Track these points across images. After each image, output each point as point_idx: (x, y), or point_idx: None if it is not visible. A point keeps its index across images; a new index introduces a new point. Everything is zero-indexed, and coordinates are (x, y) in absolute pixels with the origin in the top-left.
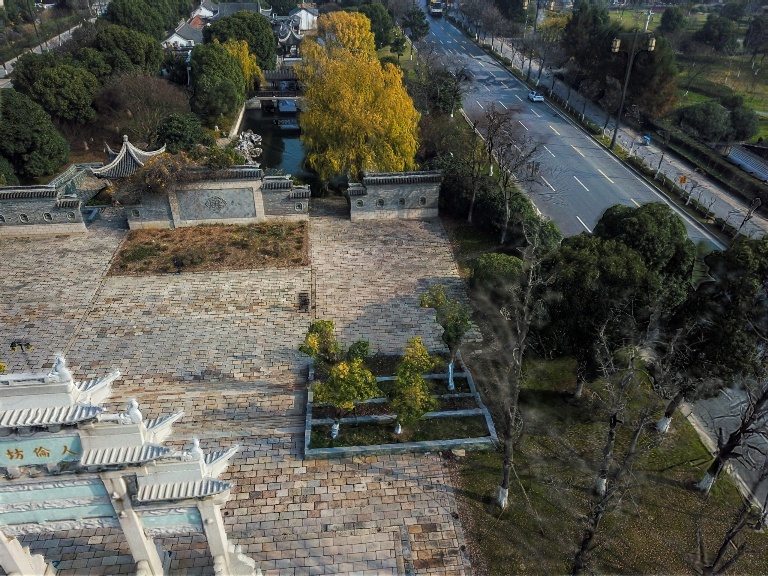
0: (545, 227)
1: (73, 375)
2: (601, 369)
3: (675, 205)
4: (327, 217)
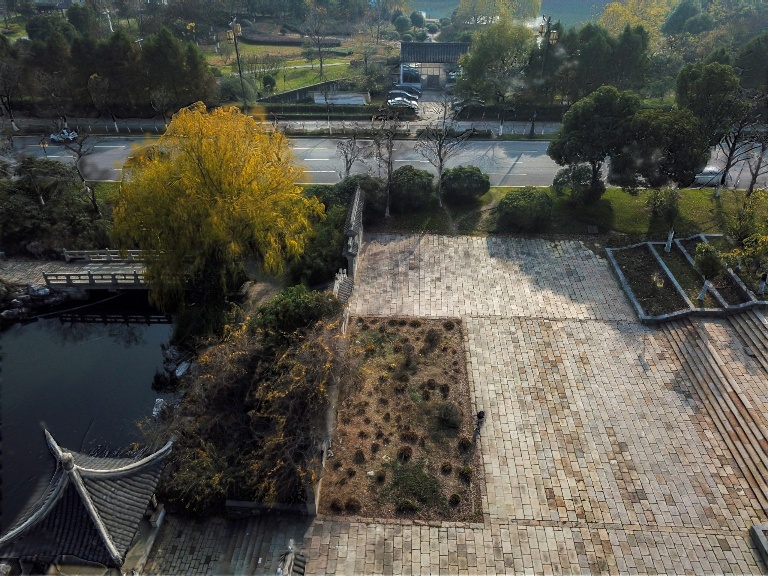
0: None
1: (730, 509)
2: None
3: None
4: None
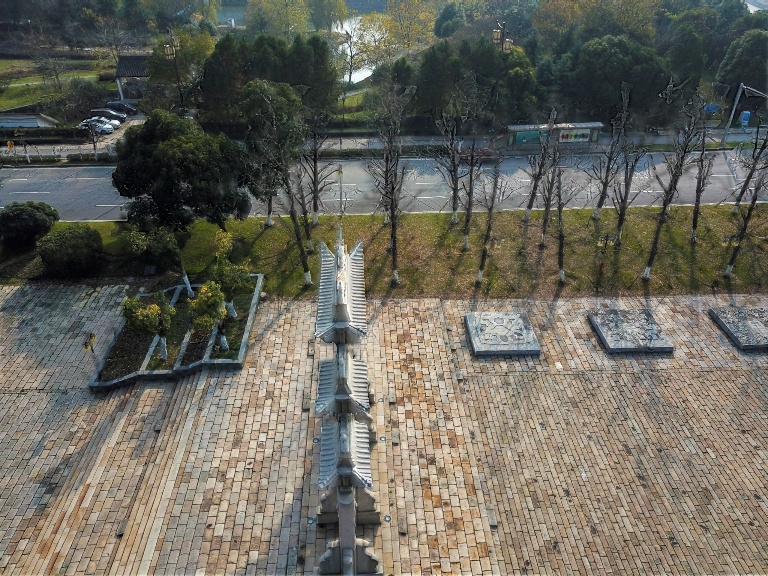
0: (34, 204)
1: None
2: (250, 202)
3: (24, 166)
4: None
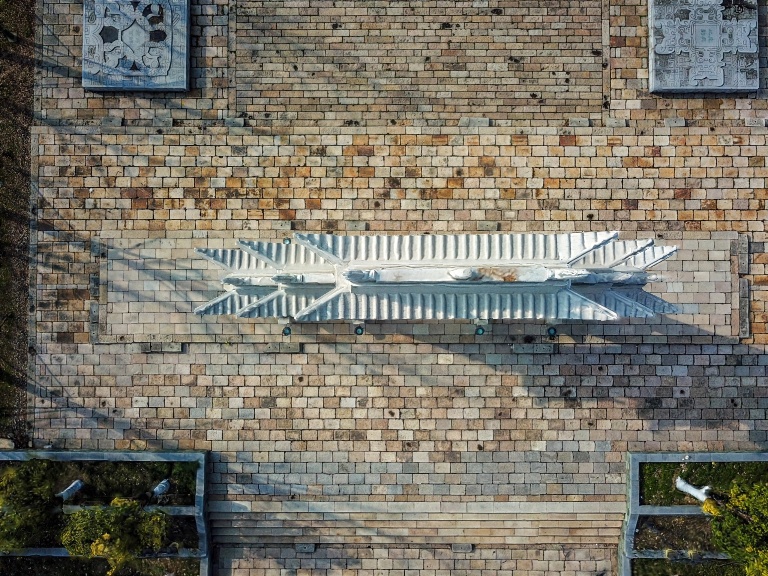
0: None
1: None
2: None
3: None
4: None
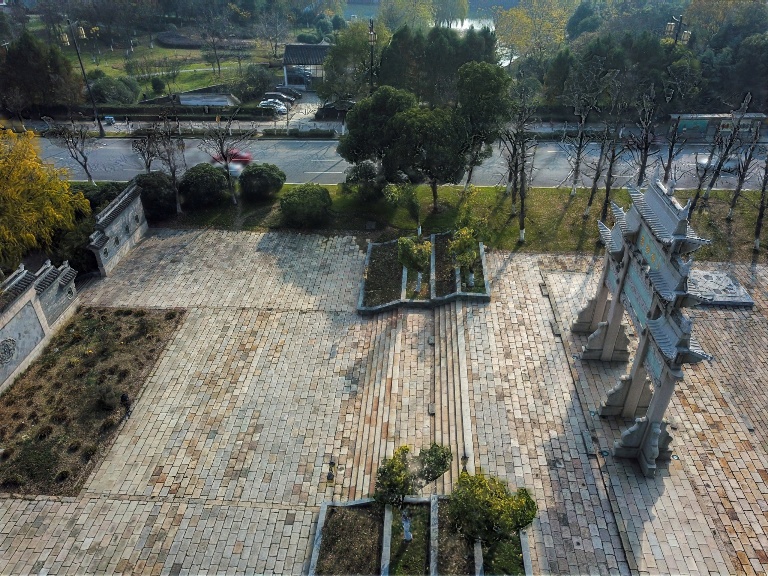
0: None
1: (319, 486)
2: None
3: None
4: (82, 291)
